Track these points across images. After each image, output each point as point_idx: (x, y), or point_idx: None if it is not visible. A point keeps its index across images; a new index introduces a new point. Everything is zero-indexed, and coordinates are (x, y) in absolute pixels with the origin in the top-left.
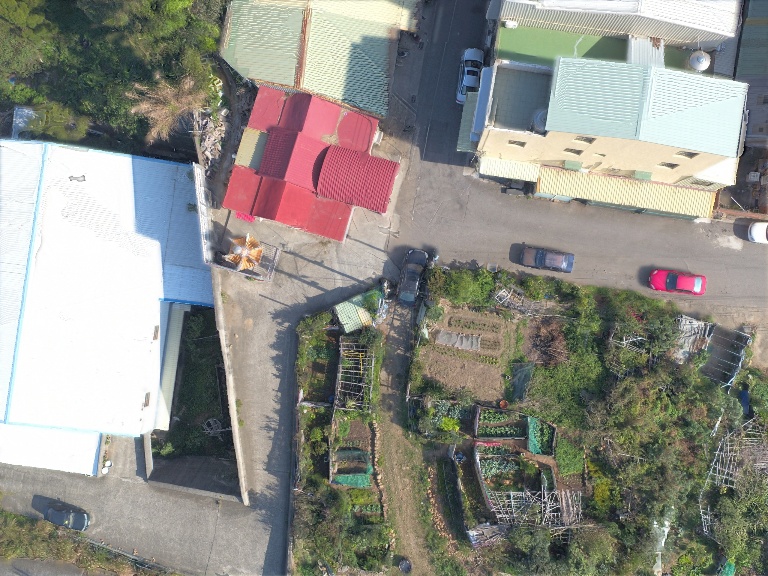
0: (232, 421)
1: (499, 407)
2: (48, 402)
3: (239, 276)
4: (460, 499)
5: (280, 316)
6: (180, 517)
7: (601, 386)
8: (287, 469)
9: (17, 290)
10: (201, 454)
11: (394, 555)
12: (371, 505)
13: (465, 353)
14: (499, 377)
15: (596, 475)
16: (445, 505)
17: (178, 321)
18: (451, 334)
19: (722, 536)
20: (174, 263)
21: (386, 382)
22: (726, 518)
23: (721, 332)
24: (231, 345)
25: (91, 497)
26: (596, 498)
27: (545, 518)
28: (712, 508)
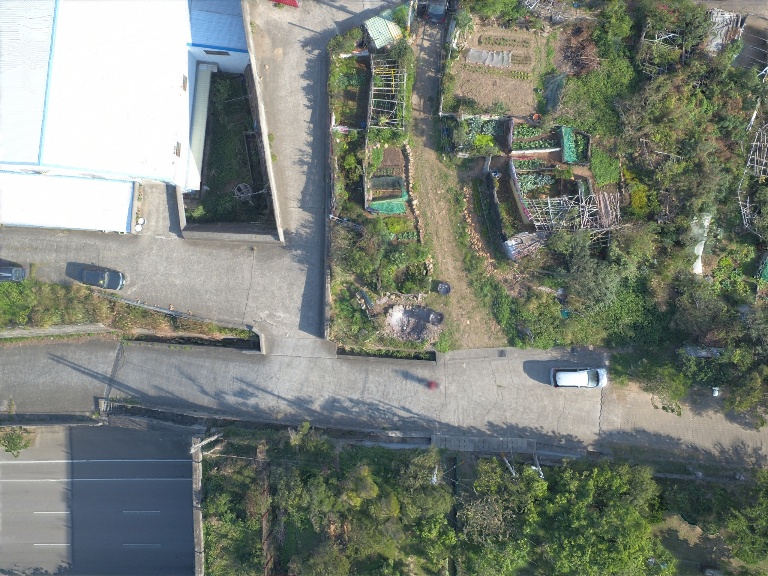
0: (266, 150)
1: (532, 121)
2: (81, 145)
3: (267, 5)
4: (497, 209)
5: (310, 44)
6: (215, 268)
7: (634, 91)
8: (321, 205)
9: (45, 40)
10: (232, 220)
11: (432, 280)
12: (407, 232)
13: (496, 70)
14: (531, 92)
15: (633, 182)
16: (482, 224)
17: (205, 81)
18: (482, 51)
19: (762, 229)
20: (201, 9)
21: (418, 106)
22: (766, 204)
23: (753, 31)
24: (261, 77)
25: (125, 258)
26: (633, 205)
27: (584, 222)
28: (751, 198)
